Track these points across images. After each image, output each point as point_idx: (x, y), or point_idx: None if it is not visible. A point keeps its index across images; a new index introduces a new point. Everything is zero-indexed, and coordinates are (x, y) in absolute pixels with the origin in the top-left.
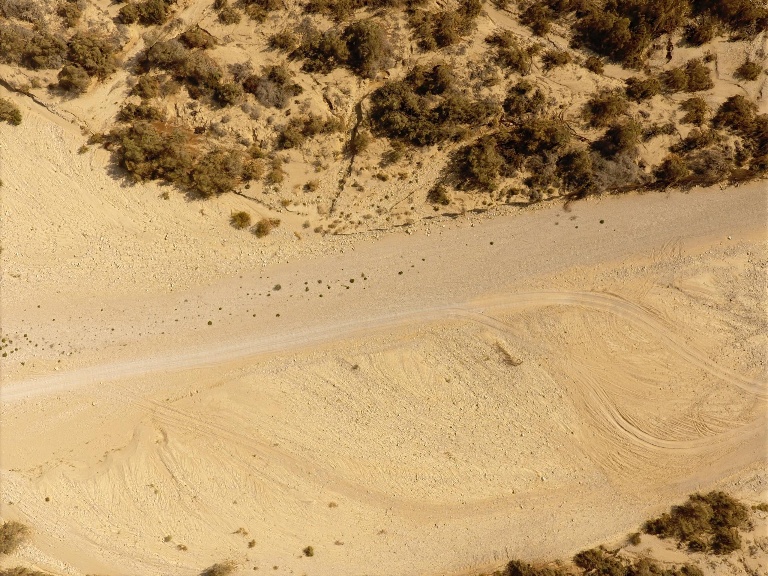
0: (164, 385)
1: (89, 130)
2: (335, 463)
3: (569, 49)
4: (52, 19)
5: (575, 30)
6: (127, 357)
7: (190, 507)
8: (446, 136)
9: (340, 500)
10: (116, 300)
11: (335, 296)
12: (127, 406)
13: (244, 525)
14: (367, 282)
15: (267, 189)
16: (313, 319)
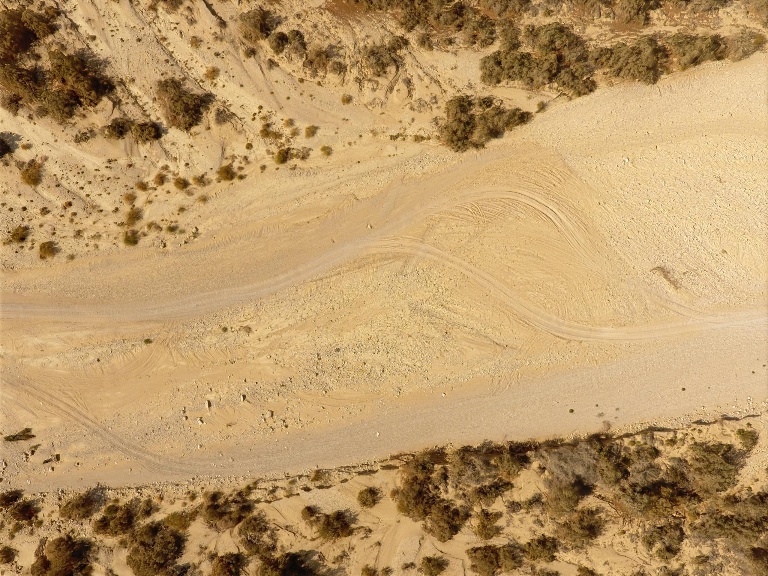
0: None
1: None
2: None
3: None
4: None
5: None
6: None
7: None
8: (747, 503)
9: None
10: None
11: None
12: None
13: None
14: None
15: None
16: None
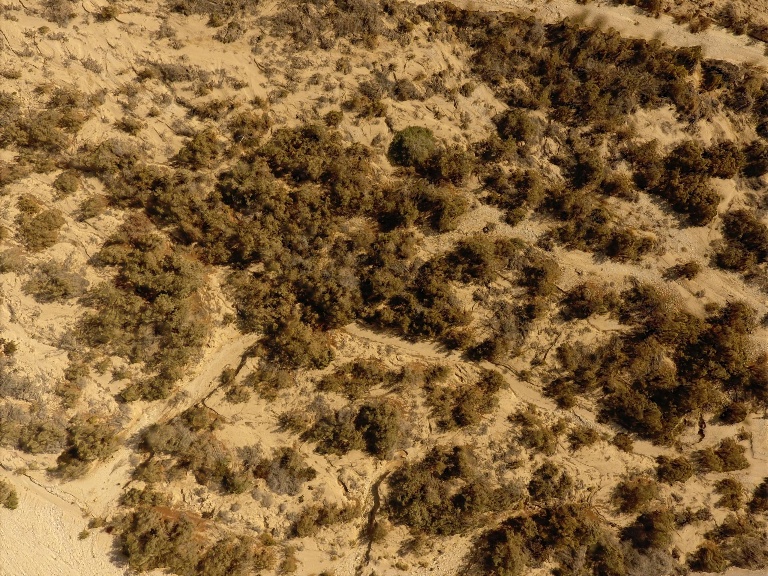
0: None
1: (90, 513)
2: None
3: (596, 424)
4: (50, 399)
5: (602, 404)
6: None
7: None
8: None
9: None
10: None
11: None
12: None
13: None
14: None
15: None
16: None
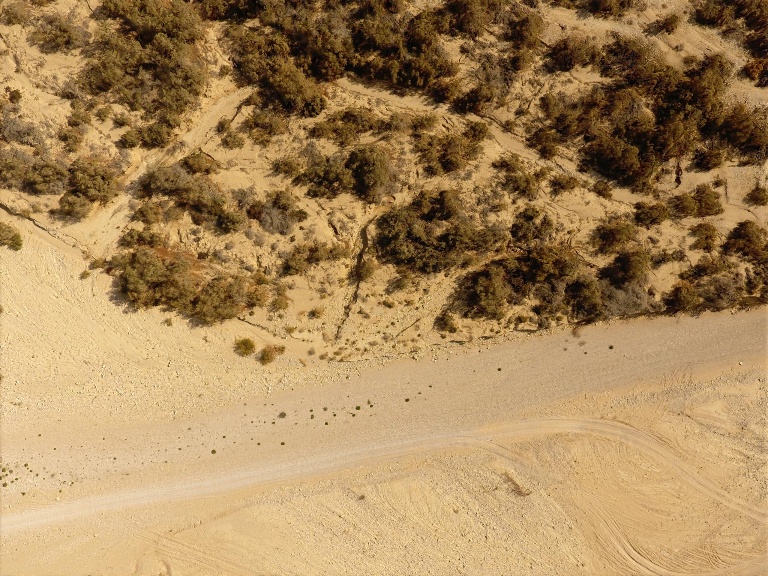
0: (167, 516)
1: (91, 255)
2: None
3: (577, 173)
4: (53, 143)
5: (583, 153)
6: (129, 487)
7: None
8: (453, 263)
9: None
10: (118, 428)
11: (341, 424)
12: (129, 537)
13: None
14: (373, 409)
15: (271, 316)
16: (319, 447)
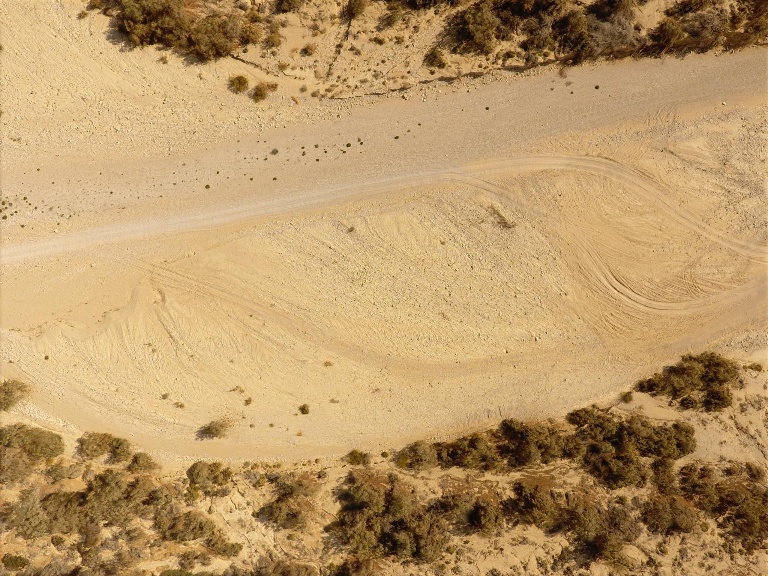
0: (162, 247)
1: None
2: (331, 323)
3: None
4: None
5: None
6: (125, 220)
7: (187, 365)
8: None
9: (335, 359)
10: (115, 164)
11: (332, 160)
12: (125, 267)
13: (240, 383)
14: (363, 146)
15: (265, 53)
16: (310, 183)
